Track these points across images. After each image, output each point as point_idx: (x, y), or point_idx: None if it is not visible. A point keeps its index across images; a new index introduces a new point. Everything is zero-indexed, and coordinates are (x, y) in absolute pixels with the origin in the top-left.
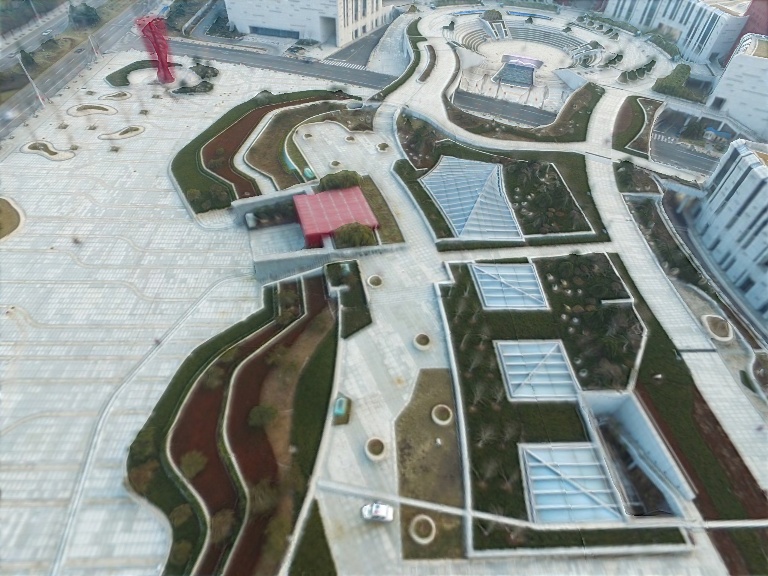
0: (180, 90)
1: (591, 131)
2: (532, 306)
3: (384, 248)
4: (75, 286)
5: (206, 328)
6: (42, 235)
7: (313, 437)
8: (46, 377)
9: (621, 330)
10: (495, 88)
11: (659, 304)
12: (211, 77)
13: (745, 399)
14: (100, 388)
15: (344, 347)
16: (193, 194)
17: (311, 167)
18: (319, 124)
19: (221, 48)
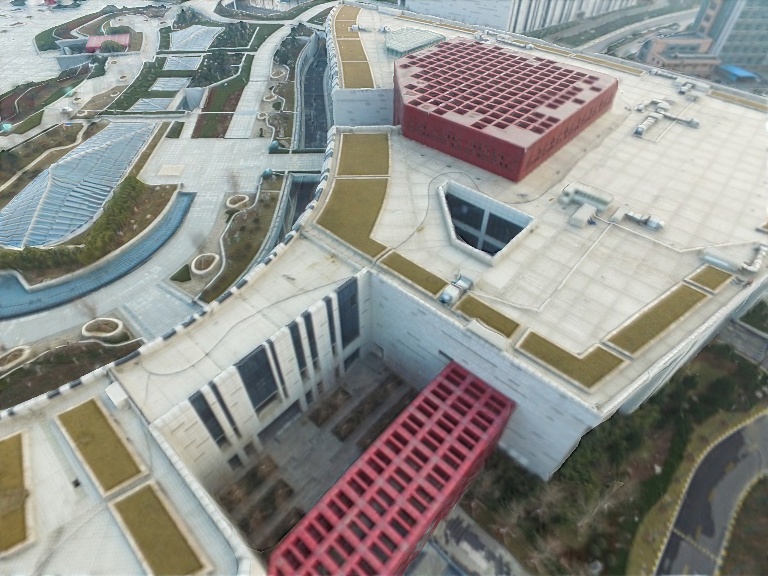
0: (57, 7)
1: (302, 15)
2: (188, 69)
3: (127, 53)
4: None
5: None
6: None
7: (54, 100)
8: None
9: None
10: (270, 2)
11: (257, 69)
12: (81, 1)
13: (263, 91)
14: None
15: (85, 81)
16: (40, 43)
17: None
18: (132, 16)
19: None
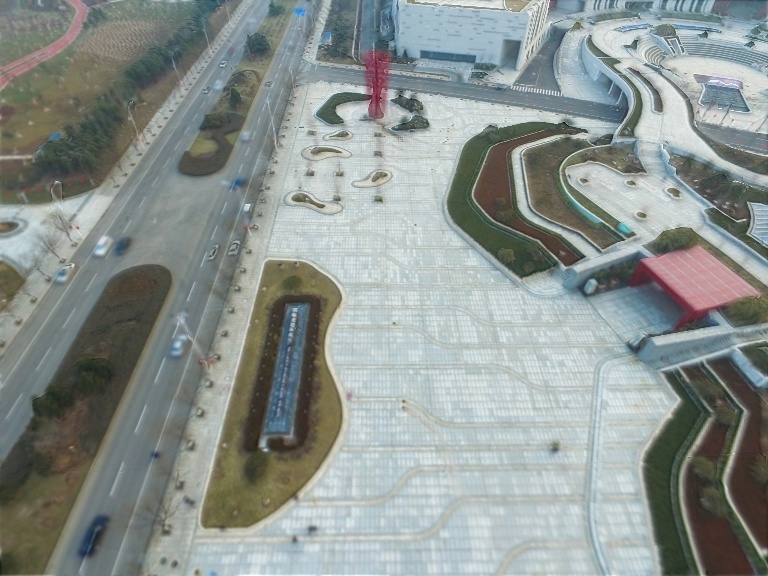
0: (400, 127)
1: None
2: None
3: None
4: (450, 372)
5: (632, 427)
6: (373, 307)
7: None
8: (499, 494)
9: None
10: (722, 115)
11: None
12: (419, 110)
13: None
14: (567, 509)
15: None
16: (509, 255)
17: (619, 220)
18: (583, 165)
19: (403, 76)
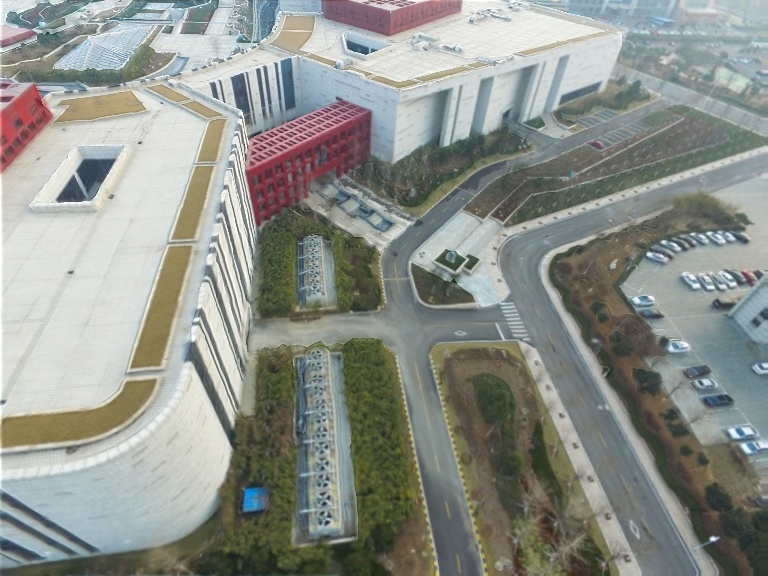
0: None
1: None
2: None
3: None
4: None
5: None
6: None
7: None
8: None
9: (198, 1)
10: None
11: None
12: None
13: None
14: None
15: None
16: None
17: None
18: None
19: None
